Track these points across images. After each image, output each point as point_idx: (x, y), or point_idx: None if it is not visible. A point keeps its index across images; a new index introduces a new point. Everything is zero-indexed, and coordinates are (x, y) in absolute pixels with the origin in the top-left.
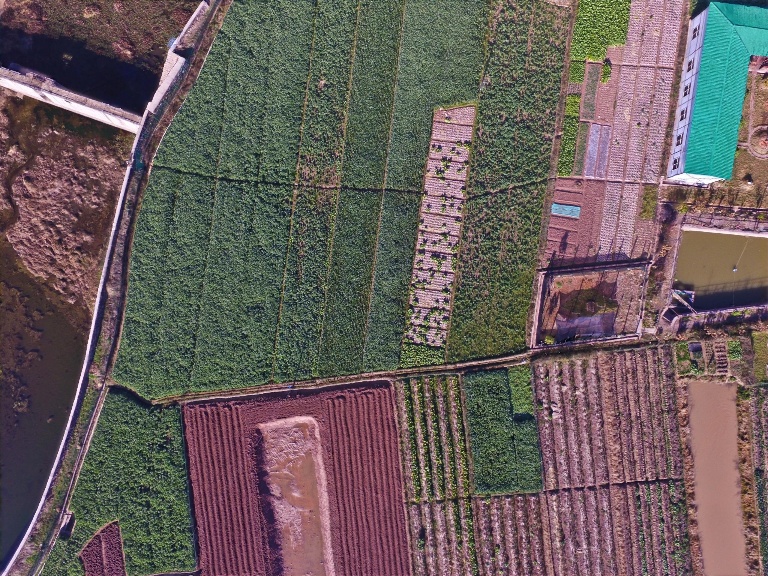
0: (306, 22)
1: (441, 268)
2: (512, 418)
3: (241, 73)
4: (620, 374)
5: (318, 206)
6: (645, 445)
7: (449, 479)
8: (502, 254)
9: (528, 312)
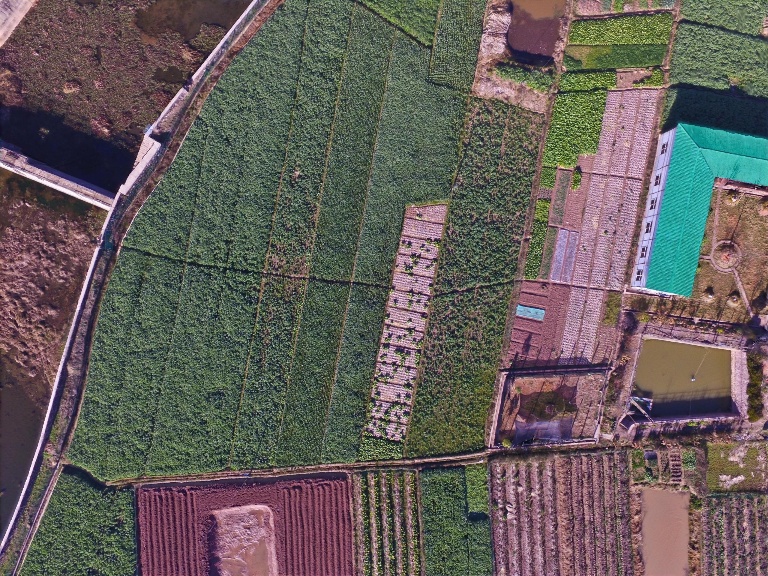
0: (284, 114)
1: (404, 363)
2: (467, 517)
3: (216, 160)
4: (576, 478)
5: (285, 295)
6: (597, 550)
7: (401, 575)
8: (466, 352)
9: (488, 411)
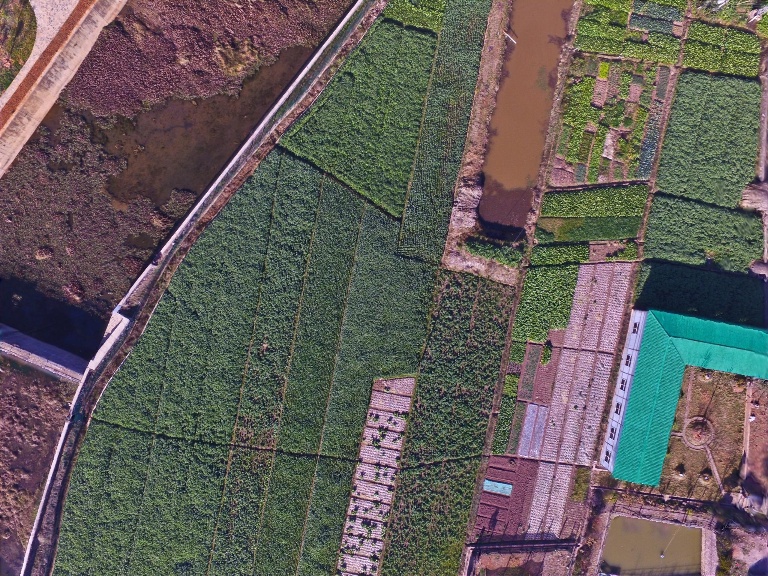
0: (252, 288)
1: (371, 535)
2: None
3: (184, 334)
4: None
5: (253, 467)
6: None
7: None
8: (432, 525)
9: None
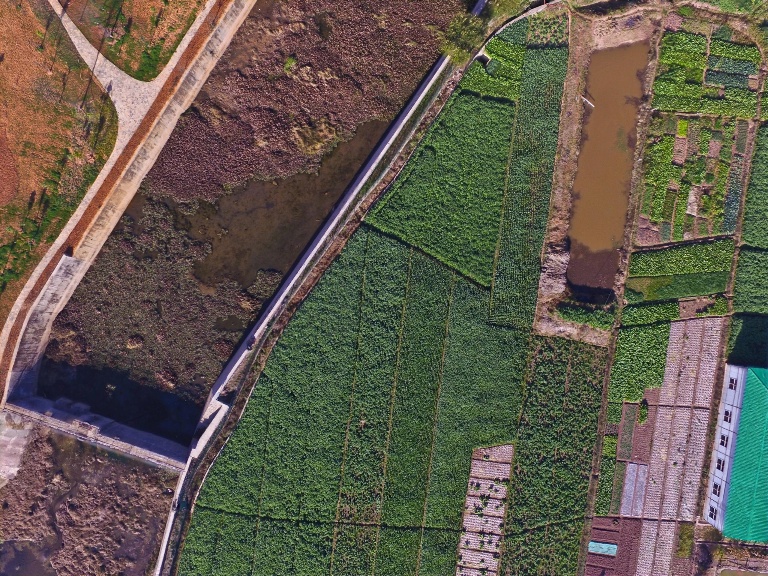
0: (347, 366)
1: None
2: None
3: (283, 416)
4: None
5: (358, 543)
6: None
7: None
8: None
9: None
